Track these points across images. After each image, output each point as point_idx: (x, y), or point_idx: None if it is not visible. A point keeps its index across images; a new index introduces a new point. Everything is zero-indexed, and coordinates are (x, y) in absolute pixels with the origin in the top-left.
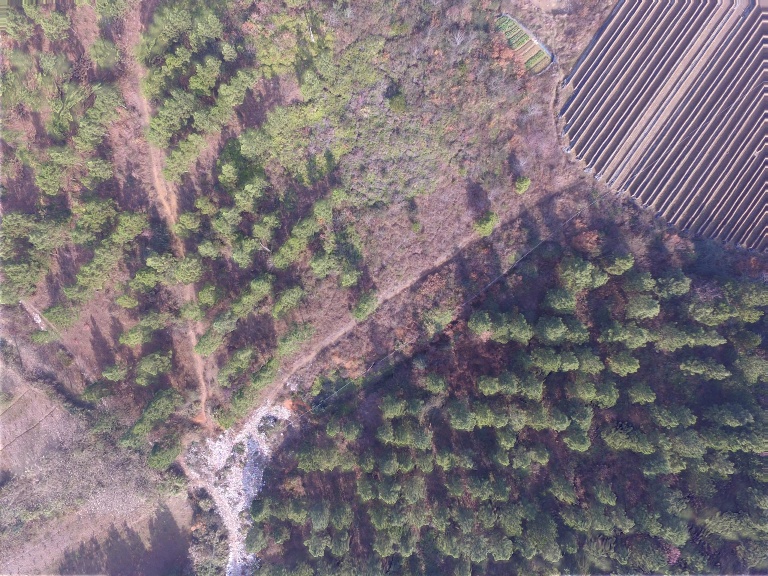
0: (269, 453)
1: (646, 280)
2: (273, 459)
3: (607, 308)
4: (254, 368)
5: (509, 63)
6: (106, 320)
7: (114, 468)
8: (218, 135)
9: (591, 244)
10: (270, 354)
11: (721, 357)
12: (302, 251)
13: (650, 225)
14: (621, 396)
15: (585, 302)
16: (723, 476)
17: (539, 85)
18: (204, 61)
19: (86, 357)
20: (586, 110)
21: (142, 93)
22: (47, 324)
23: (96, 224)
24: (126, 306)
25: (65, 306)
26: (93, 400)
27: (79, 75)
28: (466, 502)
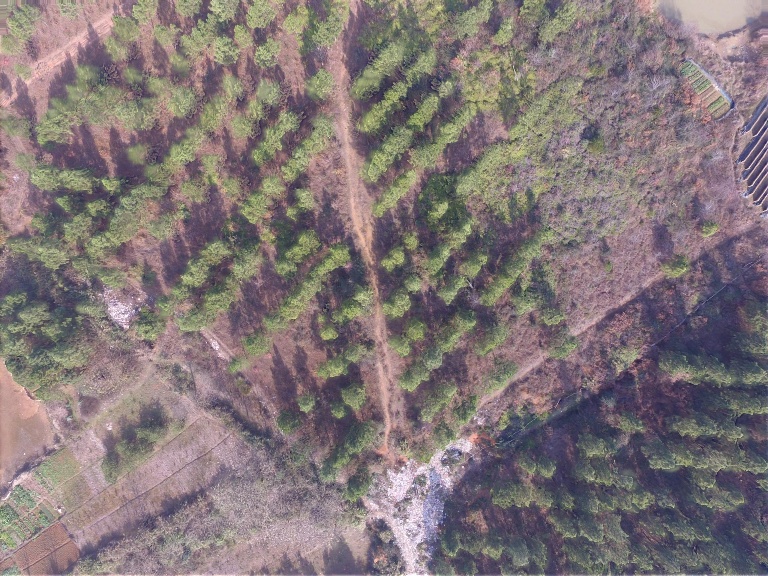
0: (451, 486)
1: None
2: (455, 492)
3: None
4: None
5: (699, 109)
6: (289, 349)
7: (291, 498)
8: (421, 169)
9: None
10: (459, 388)
11: None
12: None
13: None
14: None
15: None
16: None
17: (723, 131)
18: (418, 96)
19: (265, 385)
20: (765, 157)
21: (344, 123)
22: (225, 351)
23: (301, 255)
24: (325, 338)
25: (247, 333)
26: (270, 429)
27: (279, 102)
28: (659, 539)
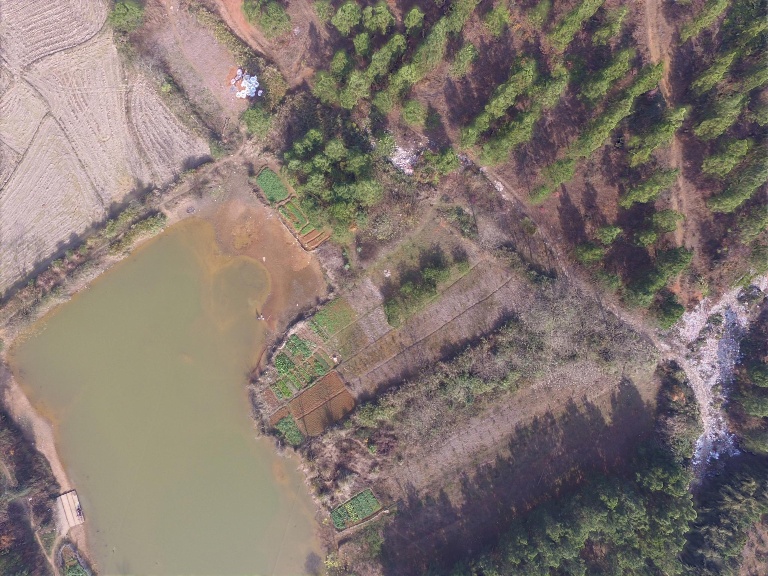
0: (747, 325)
1: None
2: (754, 330)
3: None
4: None
5: None
6: (578, 187)
7: (579, 339)
8: None
9: None
10: None
11: None
12: None
13: None
14: None
15: None
16: None
17: None
18: None
19: (551, 226)
20: None
21: None
22: (510, 192)
23: (614, 77)
24: None
25: (534, 173)
26: (554, 270)
27: None
28: None
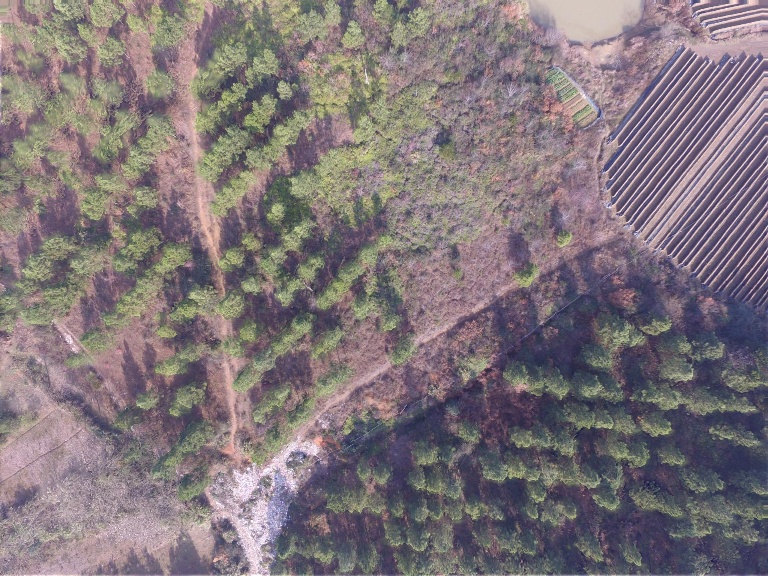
0: (296, 488)
1: (682, 344)
2: (299, 495)
3: (639, 366)
4: (287, 404)
5: (558, 117)
6: (139, 346)
7: (138, 494)
8: (267, 171)
9: (627, 301)
10: (304, 391)
11: (750, 424)
12: (344, 292)
13: (685, 286)
14: (651, 457)
15: (619, 359)
16: (747, 542)
17: (585, 140)
18: (259, 97)
19: (116, 381)
20: (629, 167)
21: (192, 123)
22: (79, 345)
23: (140, 253)
24: (164, 336)
25: (98, 329)
26: None
27: (129, 100)
28: (492, 551)
